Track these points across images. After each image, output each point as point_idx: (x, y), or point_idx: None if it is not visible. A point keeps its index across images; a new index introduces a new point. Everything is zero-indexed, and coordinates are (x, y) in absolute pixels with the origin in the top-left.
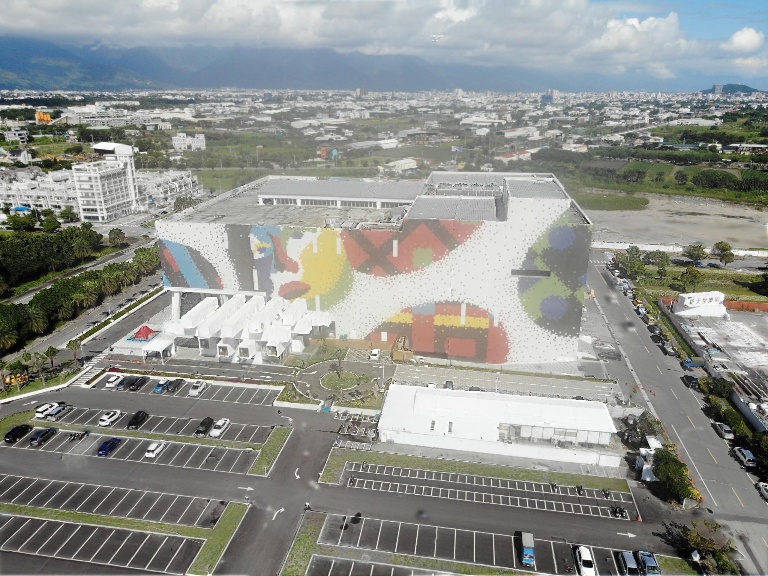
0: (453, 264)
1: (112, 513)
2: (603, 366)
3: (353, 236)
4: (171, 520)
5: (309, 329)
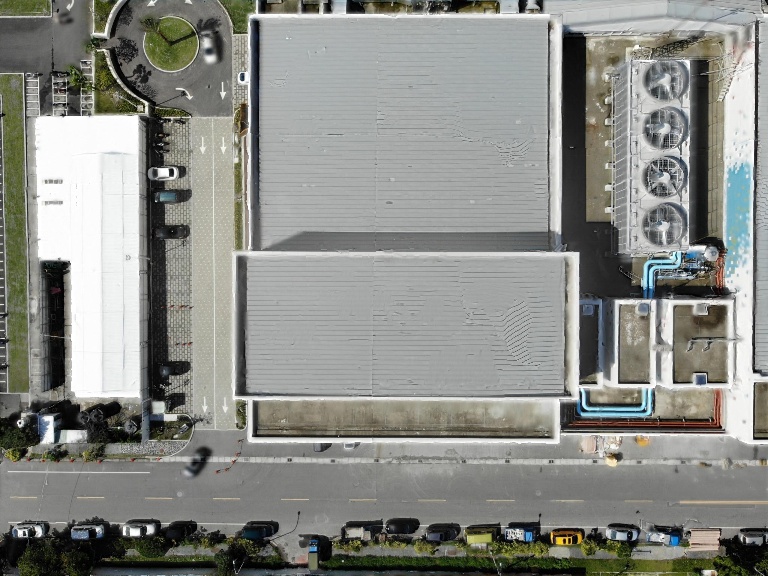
0: None
1: None
2: None
3: None
4: None
5: None
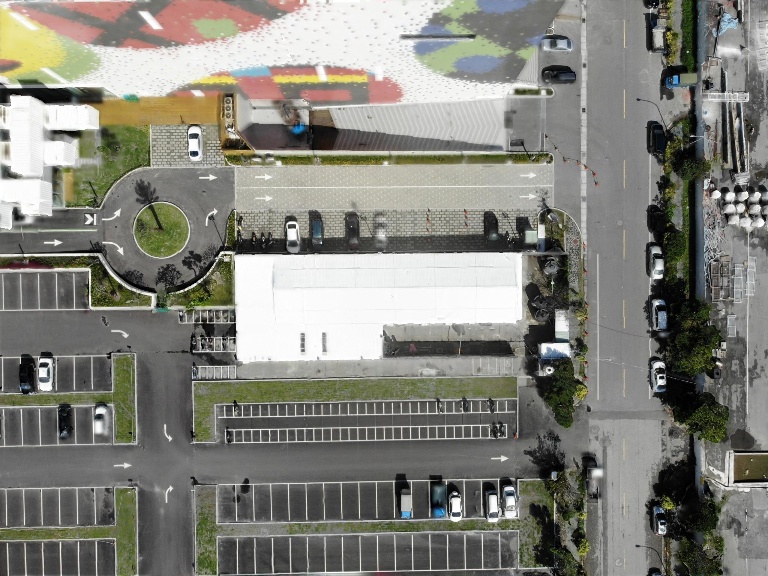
0: (282, 33)
1: (8, 524)
2: (543, 109)
3: (42, 10)
4: (70, 523)
5: (71, 159)
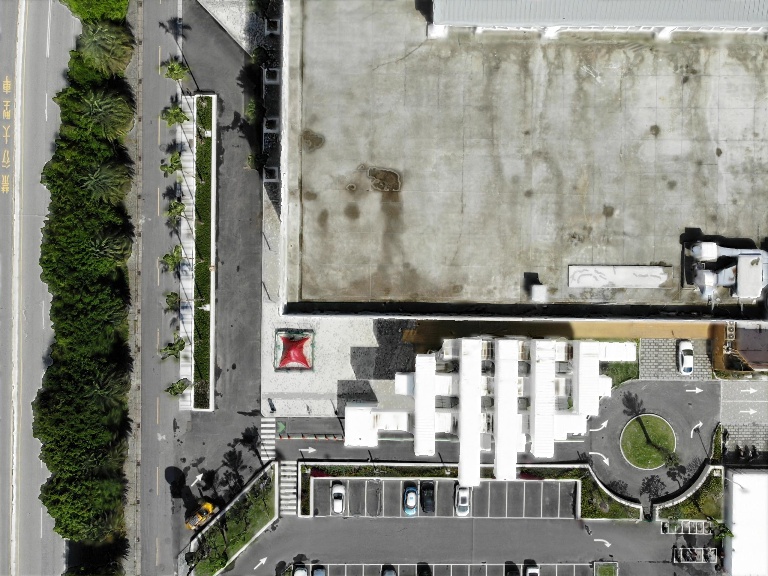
0: None
1: None
2: None
3: None
4: None
5: None
